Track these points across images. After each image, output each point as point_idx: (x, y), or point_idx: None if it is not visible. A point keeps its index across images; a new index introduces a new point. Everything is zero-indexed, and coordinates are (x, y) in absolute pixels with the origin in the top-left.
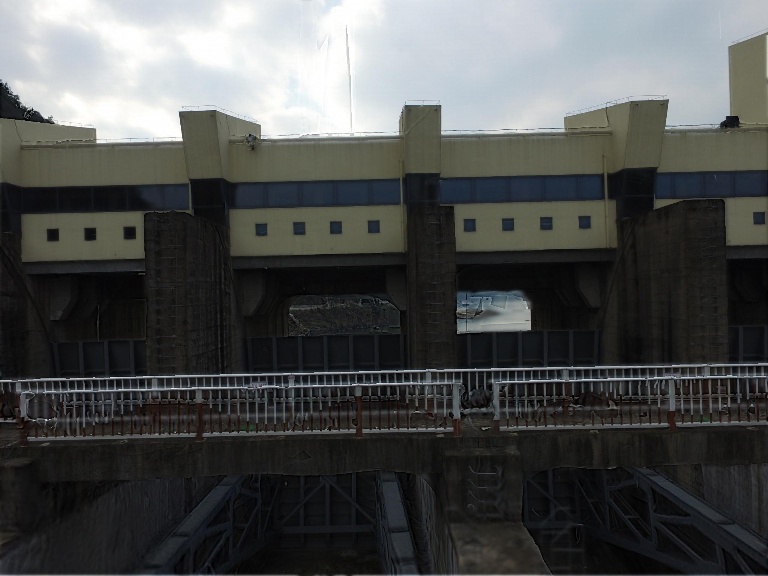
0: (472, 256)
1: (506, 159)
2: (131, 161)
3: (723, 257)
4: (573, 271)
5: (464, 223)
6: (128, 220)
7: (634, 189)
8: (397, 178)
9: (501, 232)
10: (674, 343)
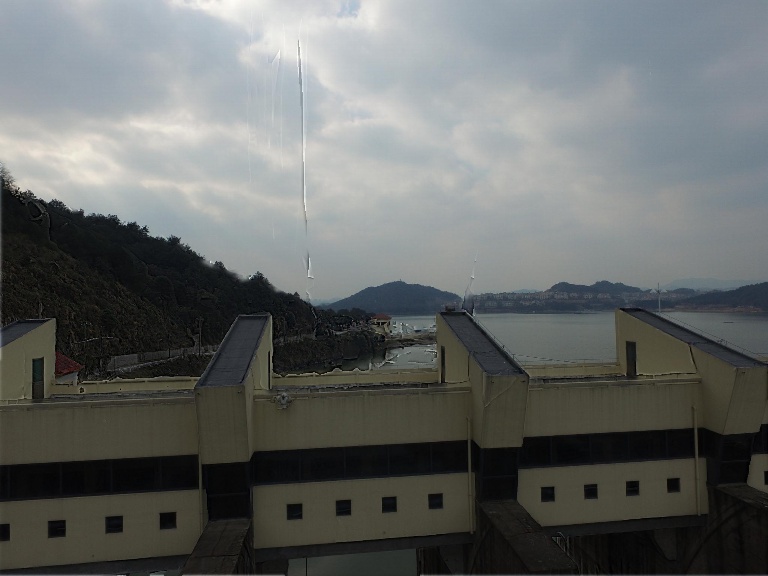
0: (550, 530)
1: (588, 413)
2: (118, 426)
3: None
4: None
5: (541, 492)
6: (112, 507)
7: (729, 452)
8: (464, 440)
9: (583, 501)
10: None
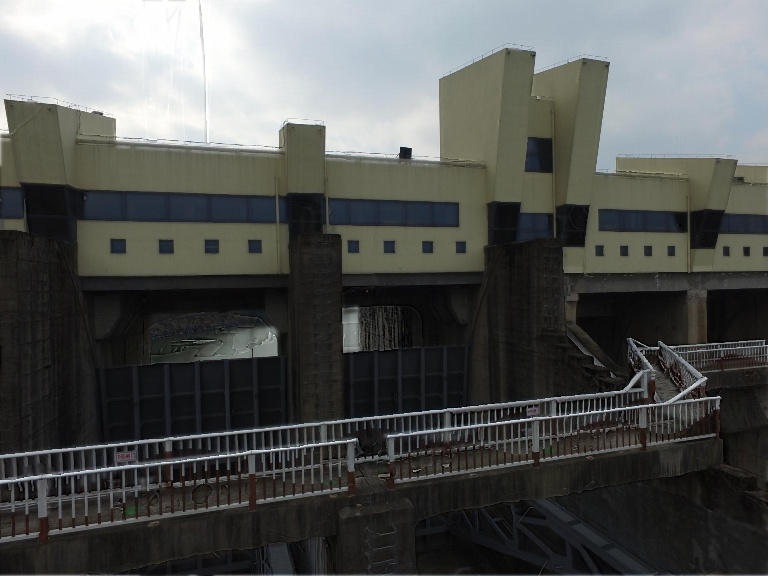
0: (123, 281)
1: (165, 173)
2: None
3: (338, 293)
4: (263, 295)
5: (111, 243)
6: None
7: (303, 214)
8: (20, 186)
9: (158, 255)
10: (299, 380)
